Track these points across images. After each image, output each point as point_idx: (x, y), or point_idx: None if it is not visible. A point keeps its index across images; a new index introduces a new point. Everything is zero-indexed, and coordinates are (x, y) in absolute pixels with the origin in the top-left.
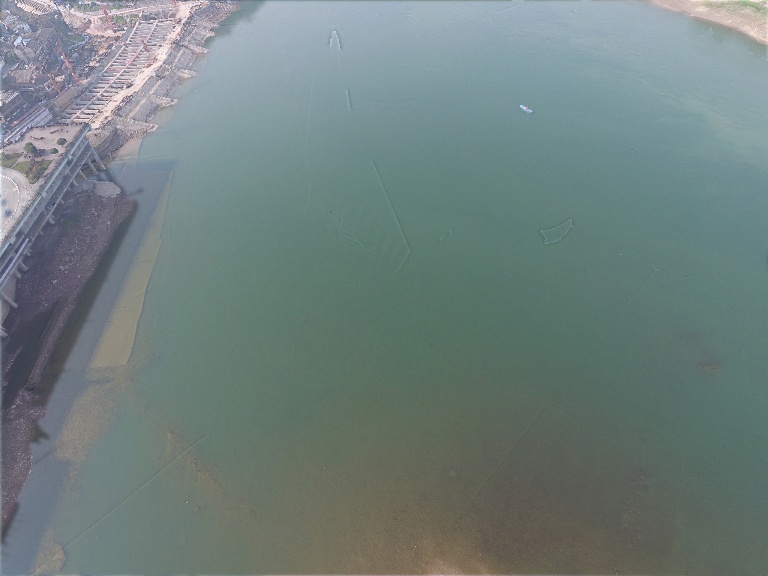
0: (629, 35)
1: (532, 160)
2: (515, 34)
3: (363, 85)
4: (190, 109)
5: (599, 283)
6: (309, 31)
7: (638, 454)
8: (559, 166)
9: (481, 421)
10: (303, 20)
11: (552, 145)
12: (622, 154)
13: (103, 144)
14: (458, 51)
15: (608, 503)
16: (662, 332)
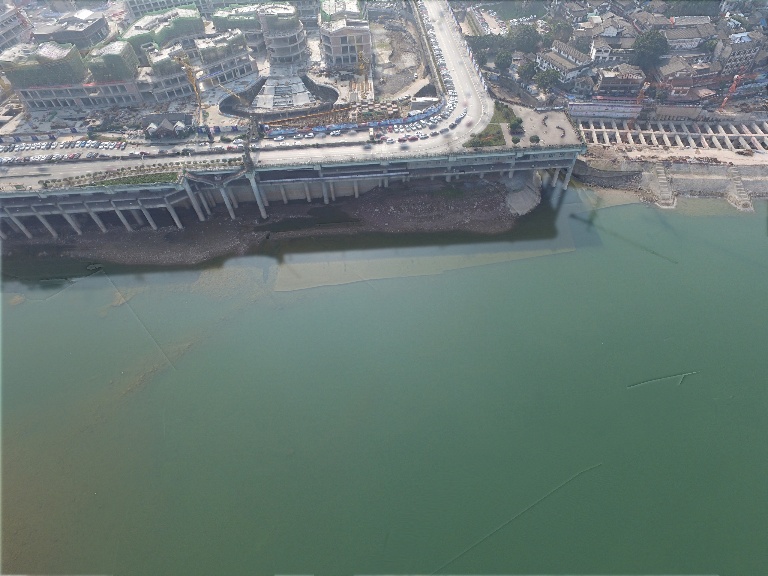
0: None
1: None
2: None
3: None
4: (734, 230)
5: None
6: None
7: None
8: None
9: None
10: None
11: None
12: None
13: (603, 172)
14: None
15: None
16: None
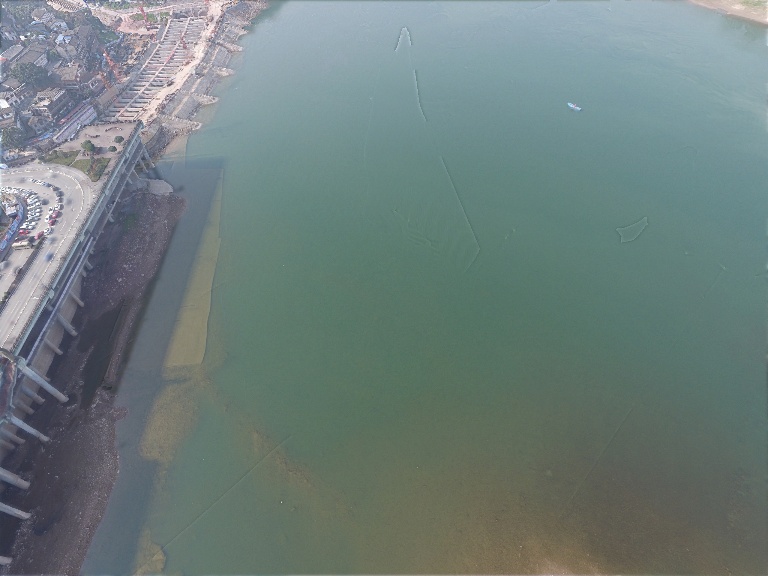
0: (667, 33)
1: (588, 158)
2: (551, 32)
3: None
4: (232, 107)
5: (671, 282)
6: (342, 29)
7: (735, 453)
8: (616, 164)
9: (570, 420)
10: (335, 18)
11: (607, 143)
12: (680, 152)
13: (151, 142)
14: (496, 49)
15: (711, 503)
16: (740, 331)
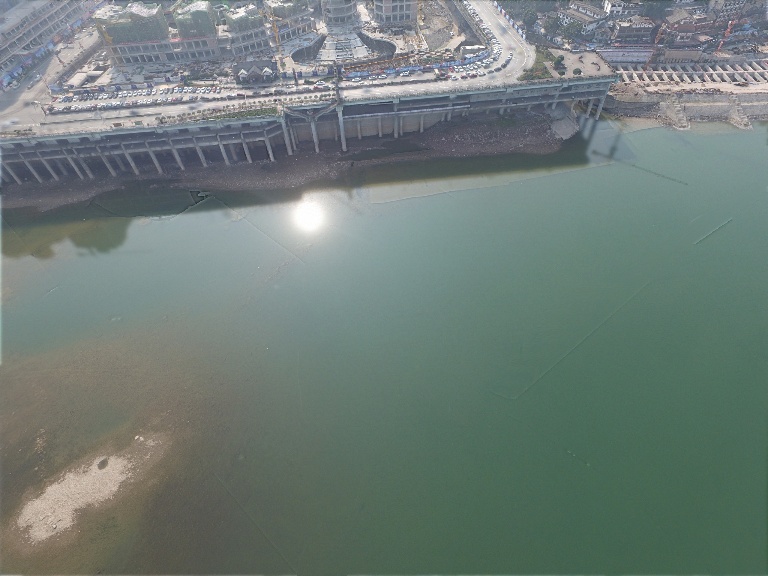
0: None
1: None
2: None
3: None
4: (740, 143)
5: None
6: None
7: None
8: None
9: (291, 490)
10: None
11: None
12: None
13: (627, 104)
14: None
15: None
16: None
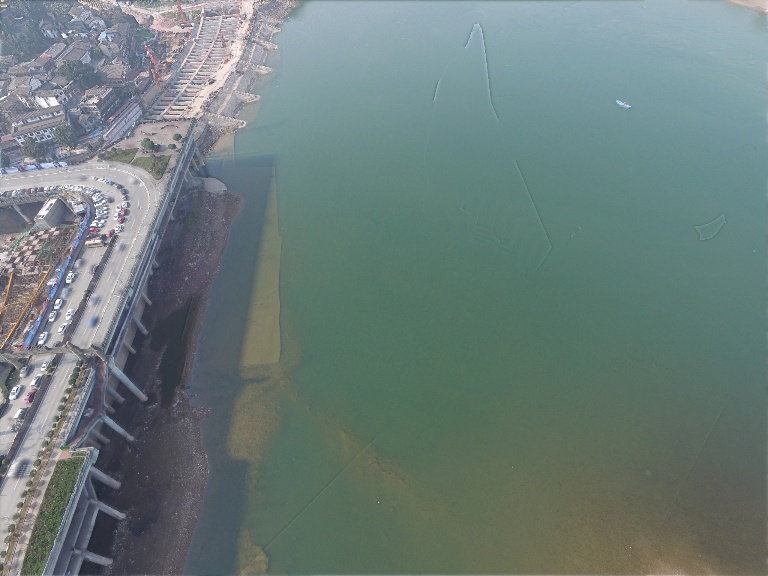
0: (706, 31)
1: (645, 156)
2: (588, 30)
3: None
4: (276, 105)
5: (746, 280)
6: (377, 27)
7: None
8: (675, 162)
9: (662, 420)
10: (368, 16)
11: (664, 141)
12: (741, 150)
13: (199, 140)
14: (535, 47)
15: None
16: None
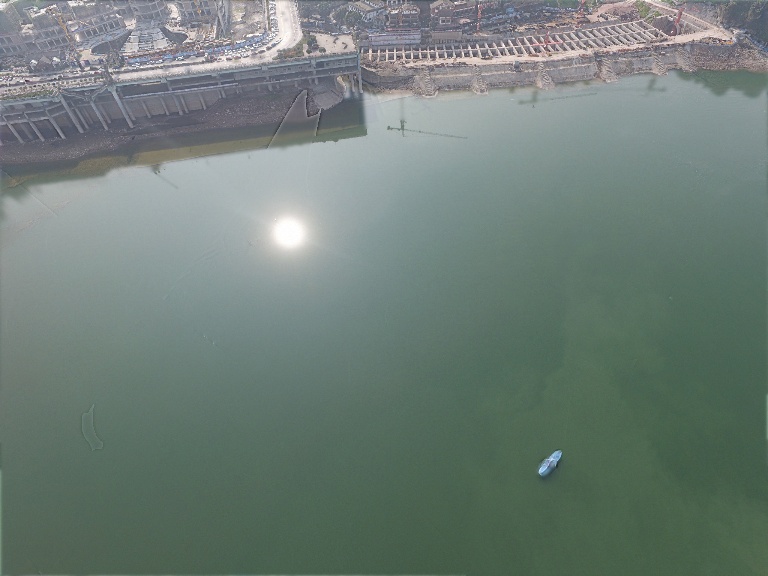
0: None
1: (357, 452)
2: None
3: (573, 225)
4: (470, 106)
5: (74, 523)
6: (731, 144)
7: None
8: (335, 496)
9: None
10: (766, 130)
11: (388, 485)
12: None
13: (387, 78)
14: None
15: None
16: None
